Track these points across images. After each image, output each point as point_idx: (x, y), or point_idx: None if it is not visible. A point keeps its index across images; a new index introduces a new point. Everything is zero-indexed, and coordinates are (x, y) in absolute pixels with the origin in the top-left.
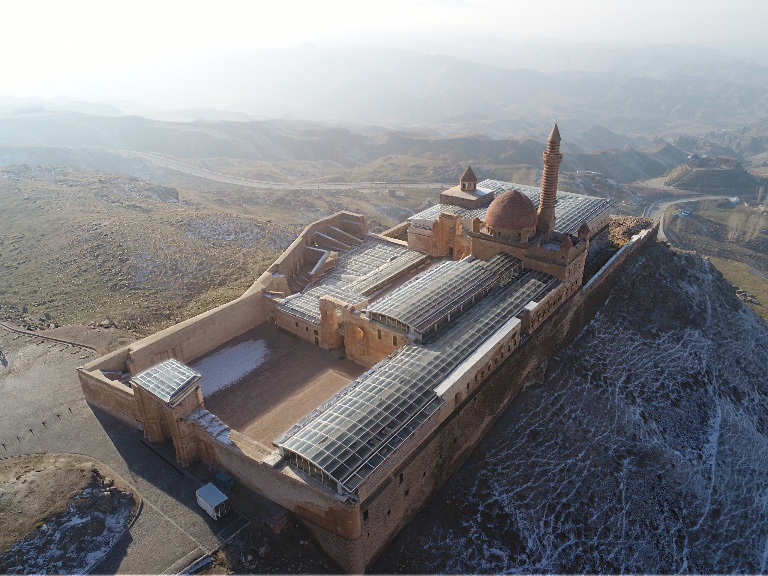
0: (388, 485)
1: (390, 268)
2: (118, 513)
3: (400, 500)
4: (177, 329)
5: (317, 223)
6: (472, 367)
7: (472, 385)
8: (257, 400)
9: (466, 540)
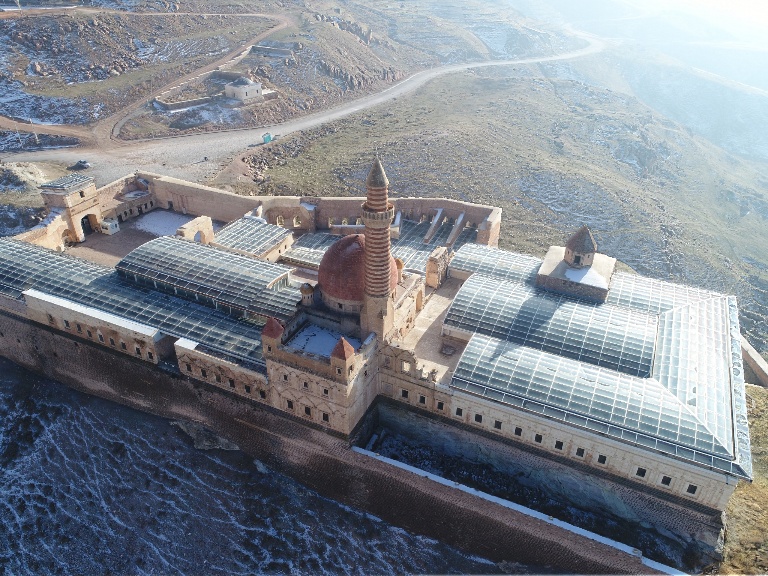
0: None
1: None
2: (25, 228)
3: None
4: (186, 184)
5: (449, 201)
6: (64, 308)
7: (72, 328)
8: None
9: (5, 410)
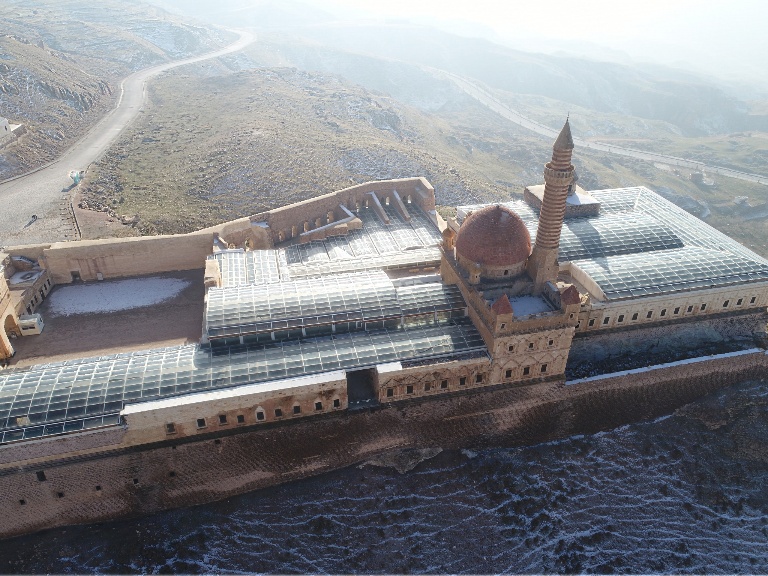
0: (11, 474)
1: (390, 257)
2: None
3: (47, 497)
4: (100, 243)
5: (377, 183)
6: (203, 403)
7: (211, 424)
8: (98, 335)
9: None
